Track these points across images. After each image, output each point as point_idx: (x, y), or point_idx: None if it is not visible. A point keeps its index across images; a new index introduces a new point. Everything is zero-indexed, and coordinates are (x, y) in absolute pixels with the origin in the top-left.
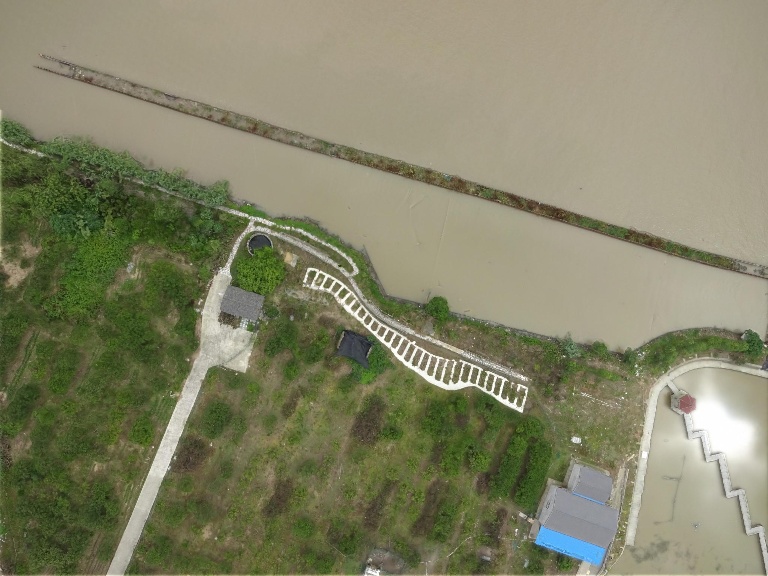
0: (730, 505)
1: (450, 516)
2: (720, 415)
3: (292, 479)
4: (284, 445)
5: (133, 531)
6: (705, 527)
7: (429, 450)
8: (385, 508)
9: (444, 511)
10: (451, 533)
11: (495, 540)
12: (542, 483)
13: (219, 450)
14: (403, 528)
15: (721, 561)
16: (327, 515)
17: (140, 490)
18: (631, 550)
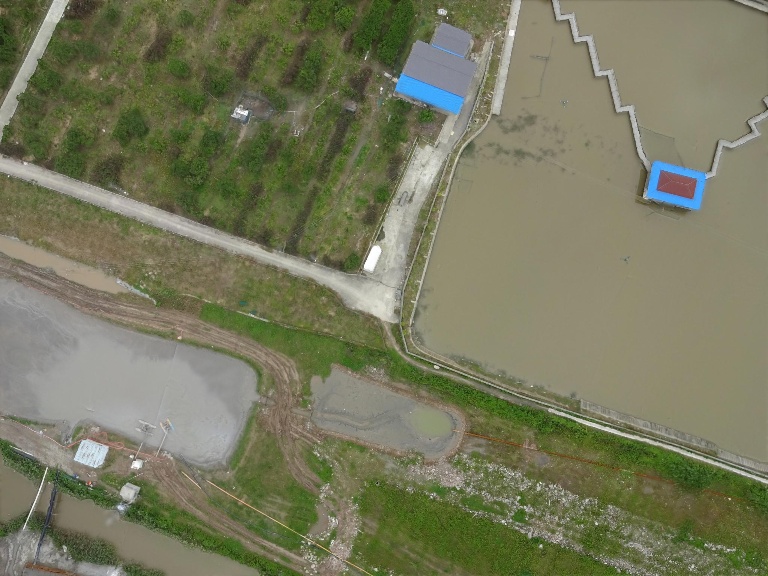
0: (600, 86)
1: (314, 62)
2: (590, 3)
3: (171, 30)
4: (166, 1)
5: (28, 67)
6: (574, 105)
7: (299, 11)
8: (257, 61)
9: (308, 56)
10: (318, 87)
11: (359, 92)
12: (403, 37)
13: (108, 3)
14: (273, 79)
15: (590, 138)
16: (201, 60)
17: (36, 33)
18: (498, 121)
